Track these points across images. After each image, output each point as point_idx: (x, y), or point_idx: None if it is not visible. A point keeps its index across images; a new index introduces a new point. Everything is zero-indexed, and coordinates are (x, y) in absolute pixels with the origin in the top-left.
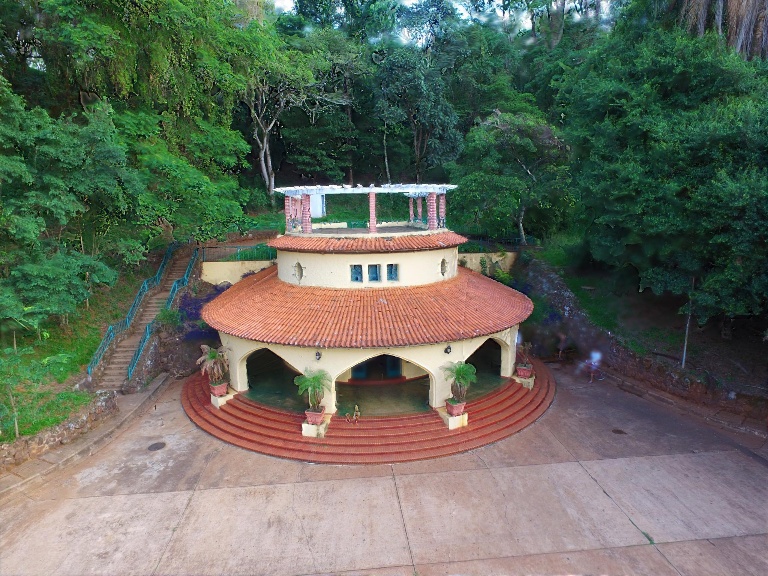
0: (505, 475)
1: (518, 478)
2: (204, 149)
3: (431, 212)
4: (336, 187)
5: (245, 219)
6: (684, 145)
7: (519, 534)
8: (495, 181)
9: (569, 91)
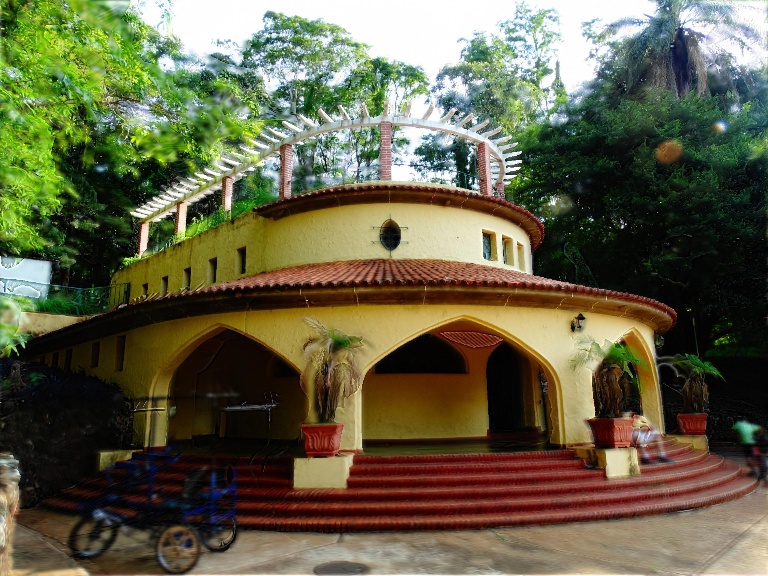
0: None
1: None
2: (6, 66)
3: None
4: None
5: (30, 231)
6: (743, 160)
7: None
8: None
9: None
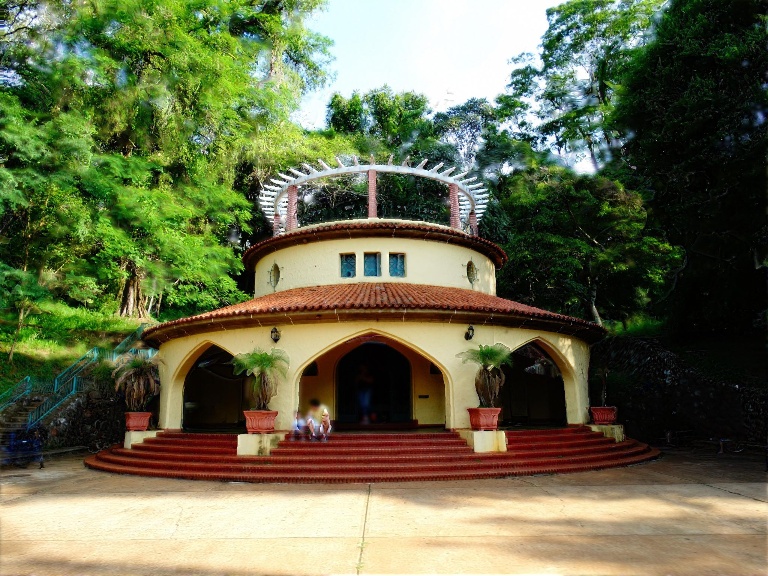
0: (567, 489)
1: (590, 491)
2: (198, 206)
3: (452, 207)
4: (328, 168)
5: (238, 295)
6: (761, 41)
7: (585, 521)
8: (549, 238)
9: None
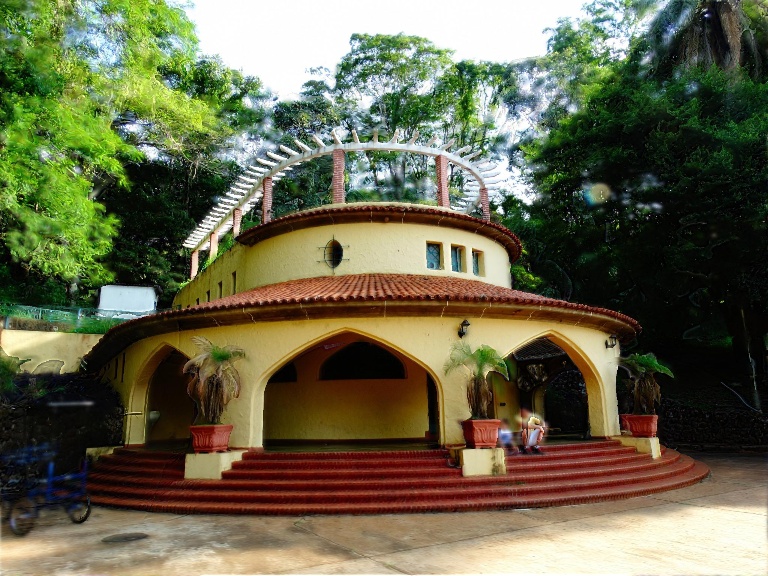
0: None
1: None
2: None
3: (485, 212)
4: None
5: (99, 267)
6: (765, 135)
7: None
8: None
9: (549, 150)
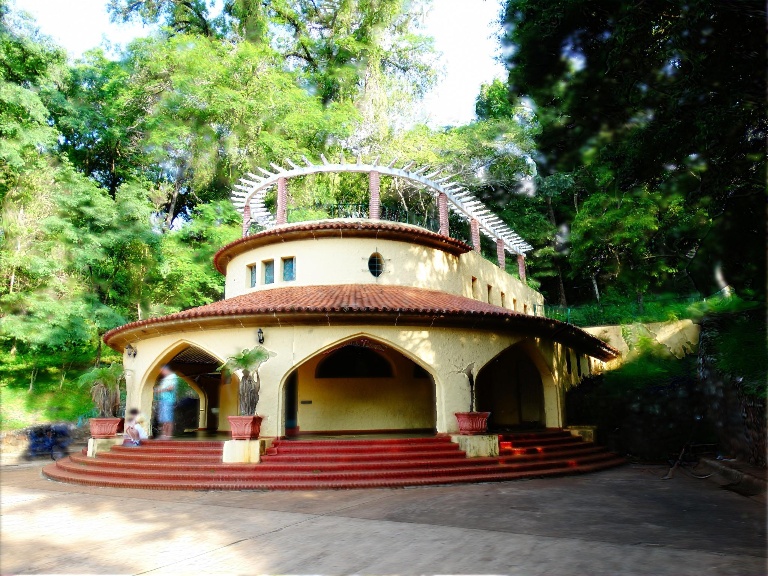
0: None
1: None
2: None
3: None
4: (255, 184)
5: None
6: None
7: None
8: None
9: None
